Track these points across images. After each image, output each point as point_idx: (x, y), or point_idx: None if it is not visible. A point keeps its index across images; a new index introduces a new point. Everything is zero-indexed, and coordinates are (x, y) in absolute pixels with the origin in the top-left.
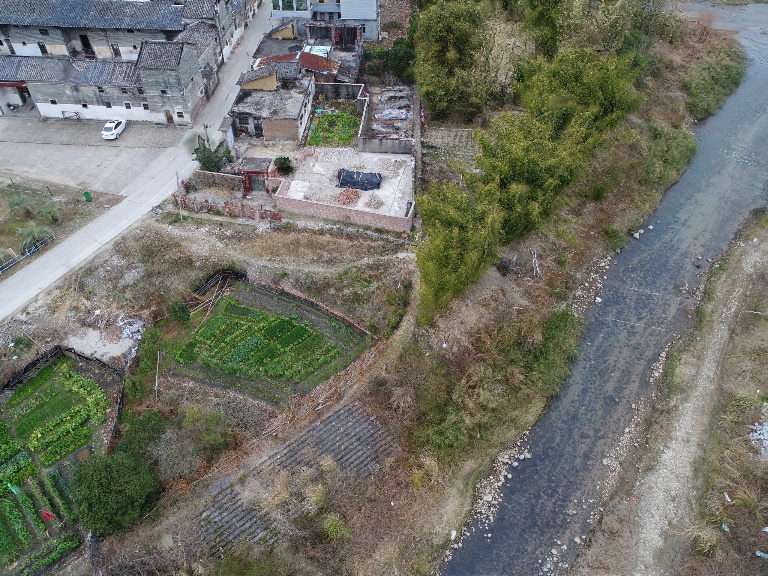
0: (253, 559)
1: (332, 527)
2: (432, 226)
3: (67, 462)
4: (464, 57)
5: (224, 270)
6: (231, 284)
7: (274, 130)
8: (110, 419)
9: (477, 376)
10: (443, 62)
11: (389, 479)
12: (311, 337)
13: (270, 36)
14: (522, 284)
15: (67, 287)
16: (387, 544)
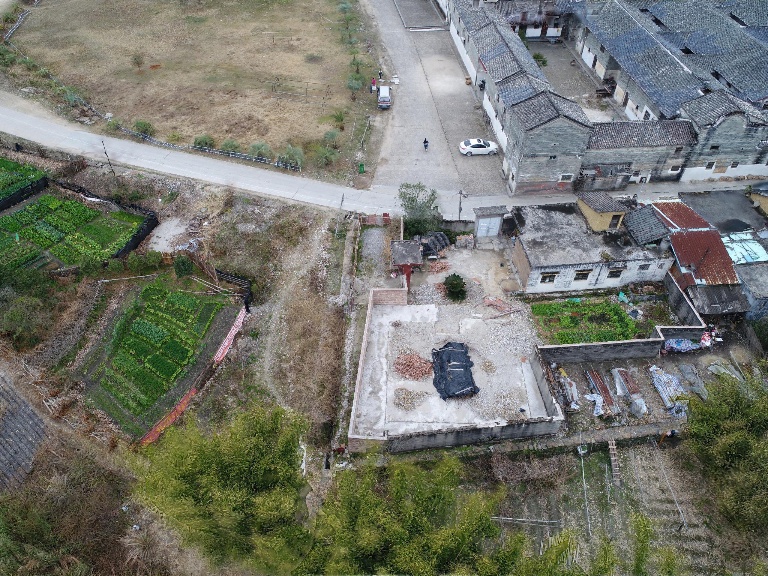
0: None
1: None
2: None
3: (50, 259)
4: None
5: None
6: None
7: None
8: None
9: (68, 573)
10: None
11: None
12: None
13: (750, 193)
14: None
15: None
16: None
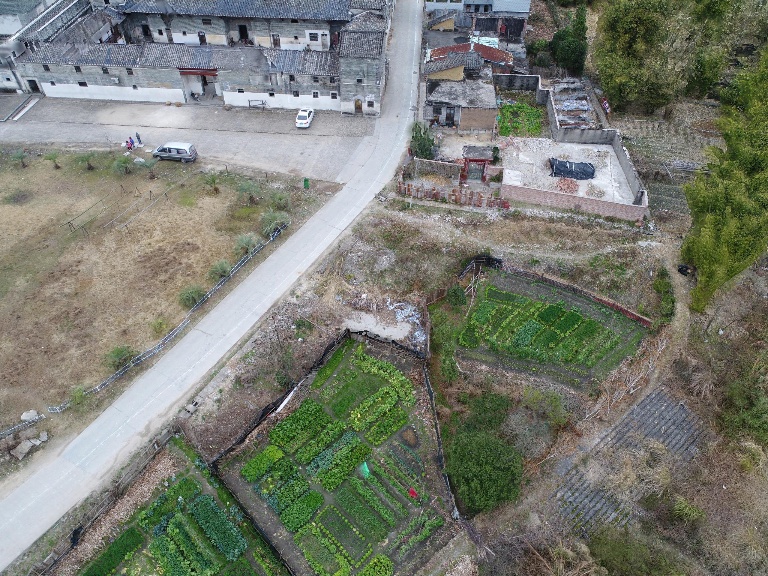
0: (614, 539)
1: (687, 508)
2: (707, 213)
3: (395, 442)
4: (650, 49)
5: (479, 256)
6: (483, 270)
7: (471, 120)
8: (421, 401)
9: None
10: (628, 53)
11: (715, 463)
12: (587, 323)
13: (431, 27)
14: (762, 274)
15: (329, 271)
16: (736, 526)
